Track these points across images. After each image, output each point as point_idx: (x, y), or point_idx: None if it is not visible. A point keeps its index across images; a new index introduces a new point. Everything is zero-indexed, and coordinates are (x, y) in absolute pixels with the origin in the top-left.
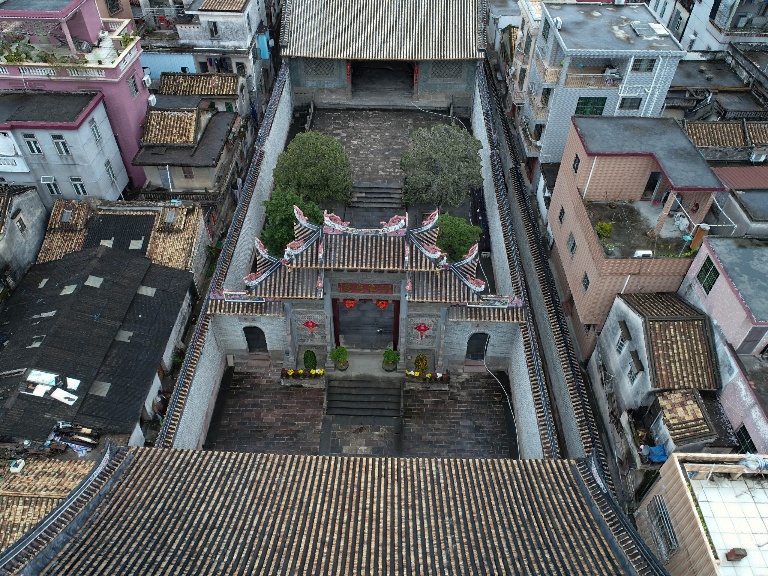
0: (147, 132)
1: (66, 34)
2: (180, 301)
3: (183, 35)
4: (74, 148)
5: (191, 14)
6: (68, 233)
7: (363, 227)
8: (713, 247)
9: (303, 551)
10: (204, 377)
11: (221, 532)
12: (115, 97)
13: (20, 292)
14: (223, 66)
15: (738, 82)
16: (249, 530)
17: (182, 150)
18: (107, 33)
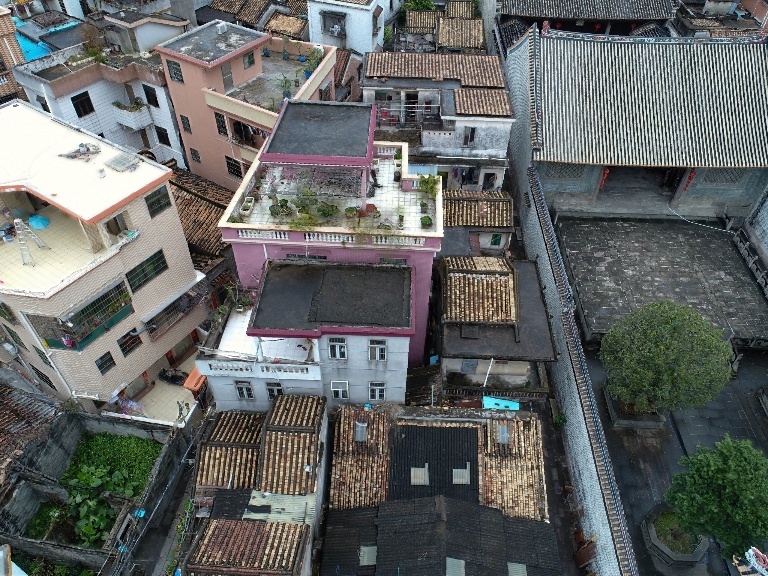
0: (449, 304)
1: (362, 183)
2: None
3: (428, 142)
4: (394, 354)
5: (438, 115)
6: (363, 456)
7: None
8: None
9: None
10: None
11: None
12: (423, 266)
13: (332, 568)
14: (471, 178)
15: None
16: None
17: (499, 331)
18: (378, 162)
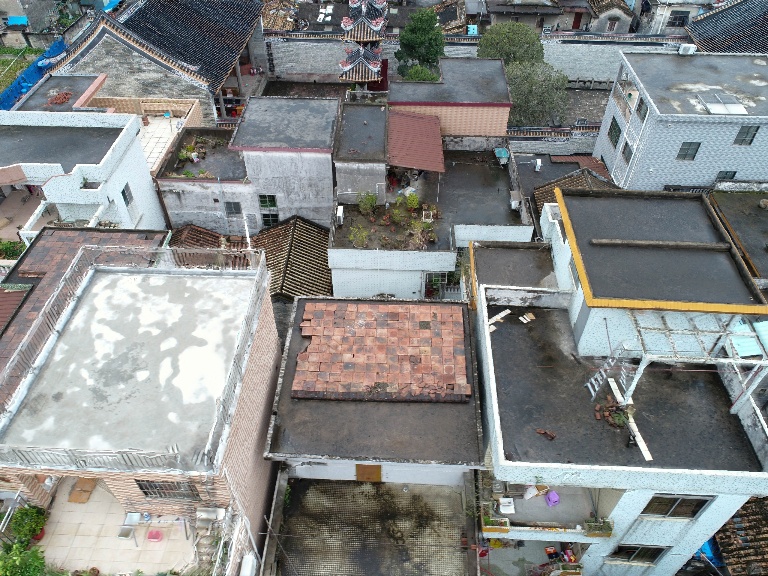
0: None
1: None
2: None
3: None
4: None
5: None
6: (442, 7)
7: (365, 4)
8: (328, 100)
9: (186, 7)
10: (339, 57)
11: (205, 1)
12: None
13: None
14: (644, 8)
15: None
16: (203, 5)
17: (503, 2)
18: None
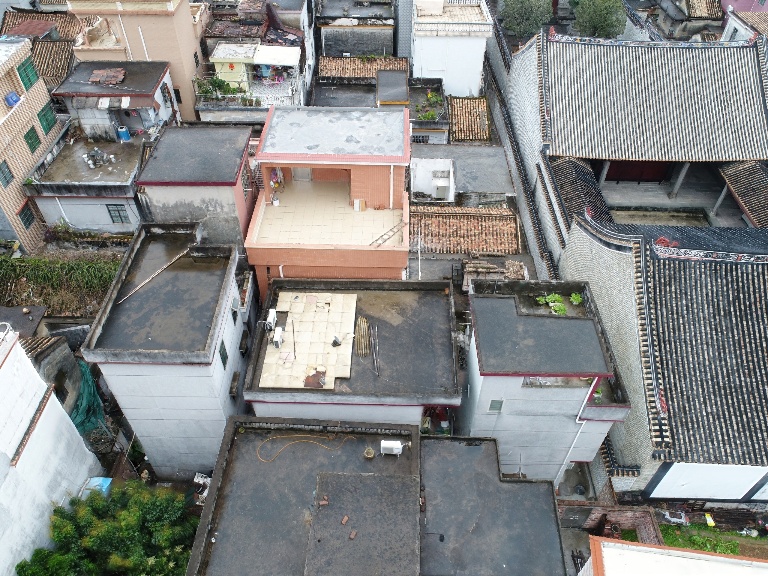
0: None
1: None
2: (628, 3)
3: None
4: None
5: None
6: None
7: None
8: None
9: None
10: None
11: None
12: None
13: None
14: None
15: (326, 9)
16: None
17: None
18: None
